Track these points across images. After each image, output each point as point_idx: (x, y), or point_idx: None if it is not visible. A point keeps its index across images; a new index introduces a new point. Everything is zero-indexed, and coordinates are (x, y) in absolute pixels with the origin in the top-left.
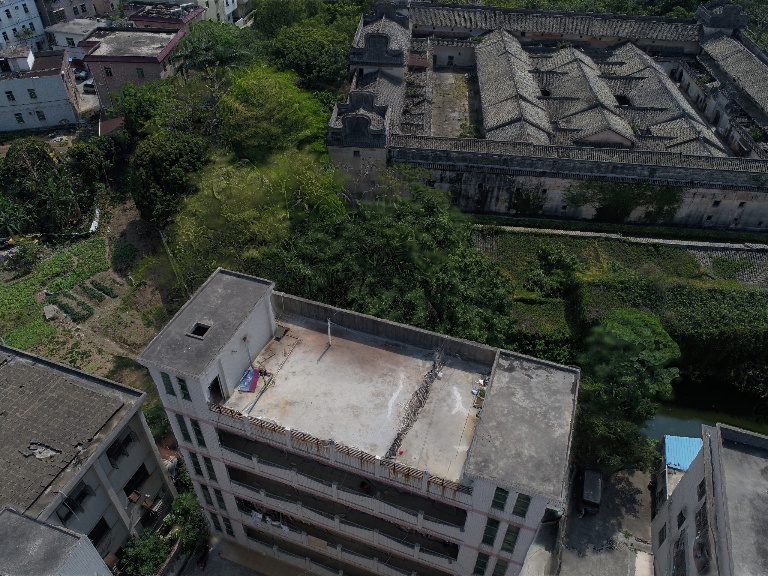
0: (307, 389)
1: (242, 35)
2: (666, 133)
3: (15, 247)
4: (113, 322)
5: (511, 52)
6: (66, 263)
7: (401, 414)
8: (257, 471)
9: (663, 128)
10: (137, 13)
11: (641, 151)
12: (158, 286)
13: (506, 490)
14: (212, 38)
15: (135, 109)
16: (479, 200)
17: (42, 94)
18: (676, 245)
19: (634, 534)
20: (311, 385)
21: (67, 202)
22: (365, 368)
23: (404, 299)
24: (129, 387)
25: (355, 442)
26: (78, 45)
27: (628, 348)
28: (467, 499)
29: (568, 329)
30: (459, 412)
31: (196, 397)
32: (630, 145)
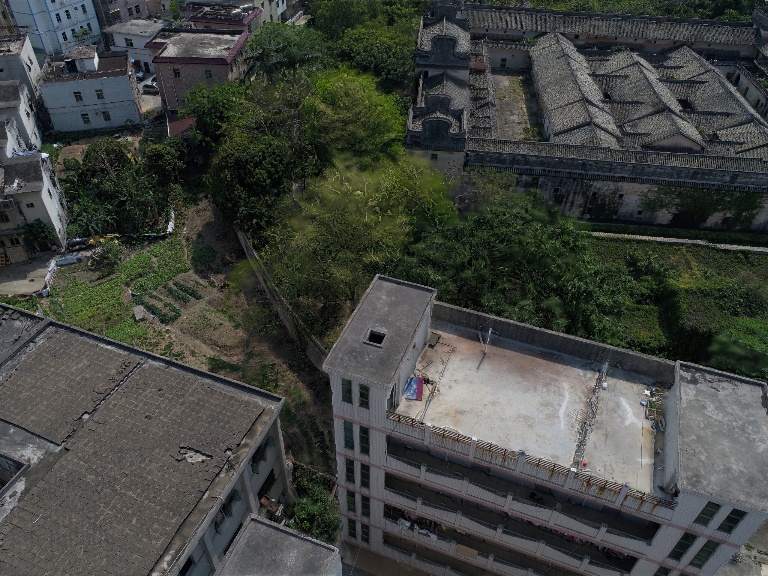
0: (474, 398)
1: (308, 37)
2: (735, 138)
3: (98, 247)
4: (201, 324)
5: (569, 55)
6: (147, 264)
7: (575, 425)
8: (422, 480)
9: (731, 133)
10: (197, 14)
11: (720, 156)
12: (242, 288)
13: (723, 506)
14: (282, 40)
15: (209, 110)
16: (553, 204)
17: (109, 95)
18: (766, 252)
19: (756, 547)
20: (477, 394)
21: (146, 203)
22: (526, 377)
23: (490, 304)
24: (267, 392)
25: (535, 453)
26: (145, 46)
27: (724, 356)
28: (667, 514)
29: (664, 336)
30: (633, 424)
31: (376, 405)
32: (700, 150)
